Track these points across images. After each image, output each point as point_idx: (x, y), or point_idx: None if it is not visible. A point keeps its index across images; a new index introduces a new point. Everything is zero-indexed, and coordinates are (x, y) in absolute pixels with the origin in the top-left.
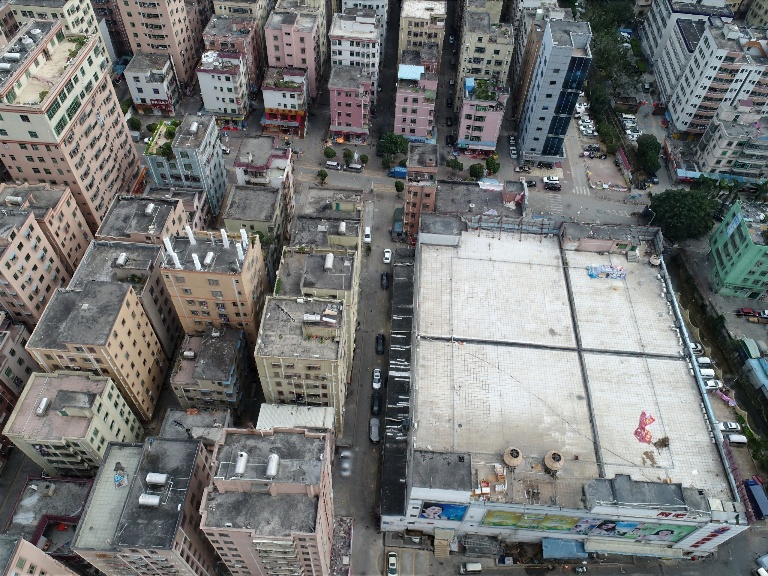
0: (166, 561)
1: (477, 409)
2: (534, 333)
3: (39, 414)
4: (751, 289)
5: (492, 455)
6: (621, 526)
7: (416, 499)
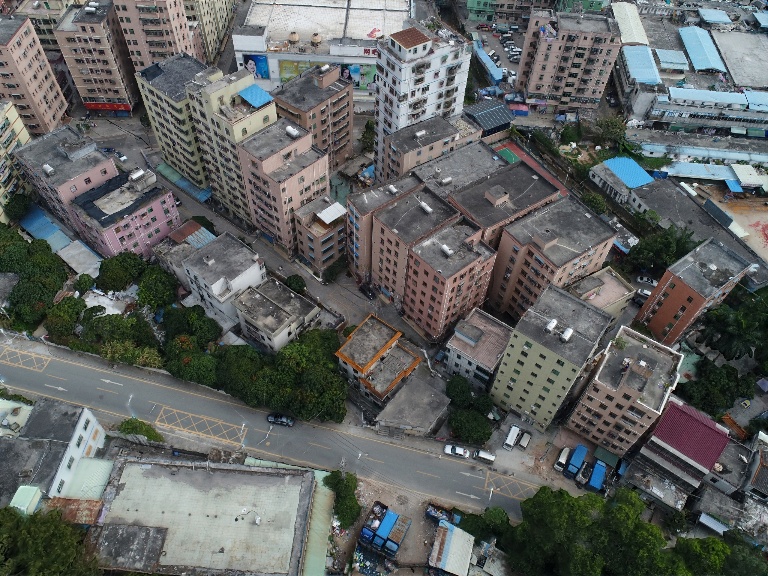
0: (100, 43)
1: (281, 27)
2: (324, 2)
3: (34, 7)
4: (485, 12)
5: (284, 40)
6: (353, 72)
7: (238, 50)
